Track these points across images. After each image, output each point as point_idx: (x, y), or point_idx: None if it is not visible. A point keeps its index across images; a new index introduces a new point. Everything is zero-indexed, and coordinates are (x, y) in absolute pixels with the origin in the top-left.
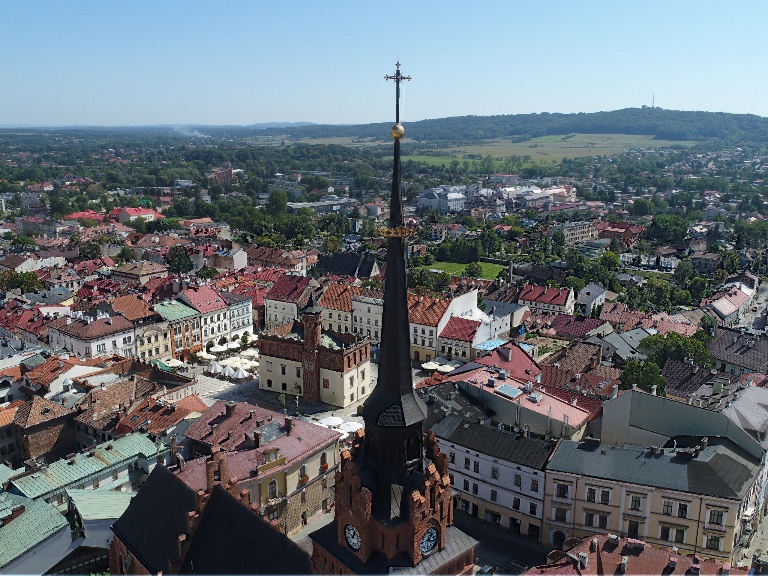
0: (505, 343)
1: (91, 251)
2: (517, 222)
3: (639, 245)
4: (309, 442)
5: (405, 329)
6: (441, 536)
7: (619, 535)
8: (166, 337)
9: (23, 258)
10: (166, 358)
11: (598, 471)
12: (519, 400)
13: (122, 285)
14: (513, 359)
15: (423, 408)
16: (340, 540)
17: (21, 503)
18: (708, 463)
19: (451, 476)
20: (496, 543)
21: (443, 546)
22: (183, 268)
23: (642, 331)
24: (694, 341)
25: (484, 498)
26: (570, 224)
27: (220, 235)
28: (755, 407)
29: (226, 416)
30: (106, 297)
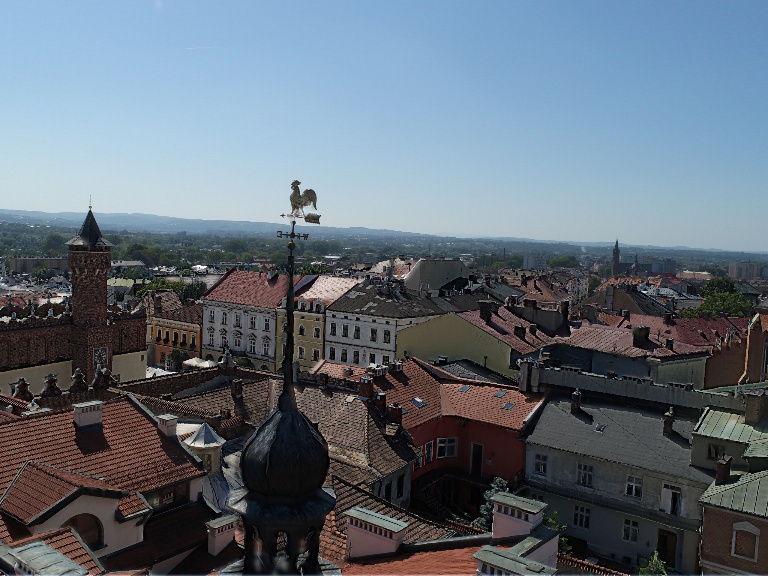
0: (226, 274)
1: None
2: None
3: None
4: None
5: None
6: None
7: None
8: None
9: None
10: None
11: None
12: None
13: None
14: None
15: None
16: None
17: None
18: None
19: None
20: None
21: None
22: None
23: None
24: None
25: None
26: None
27: None
28: None
29: None
30: None
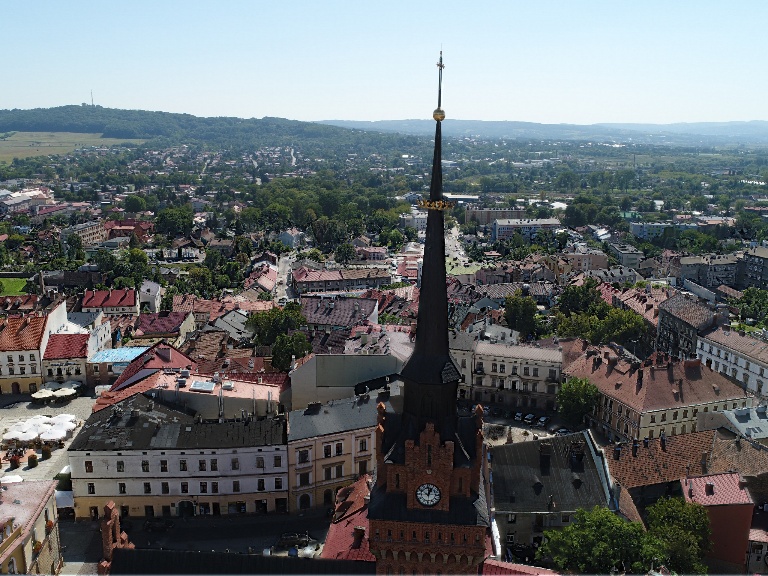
0: (154, 345)
1: None
2: (11, 230)
3: (156, 240)
4: (30, 502)
5: None
6: None
7: (353, 478)
8: None
9: None
10: None
11: (331, 428)
12: (221, 391)
13: None
14: (172, 358)
15: None
16: (411, 505)
17: None
18: (401, 395)
19: (183, 485)
20: (252, 529)
21: None
22: None
23: (236, 313)
24: (291, 312)
25: (226, 493)
26: (78, 226)
27: None
28: (402, 346)
29: None
30: None
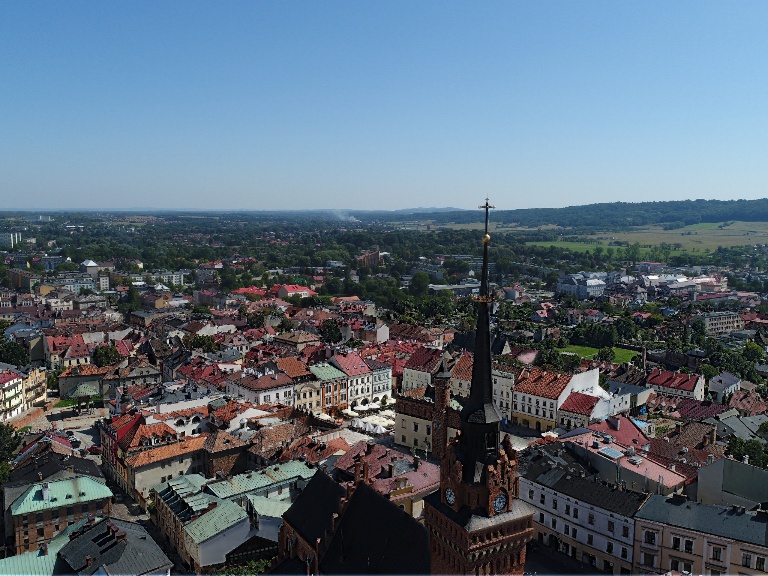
0: None
1: (257, 321)
2: (657, 310)
3: None
4: (433, 478)
5: (488, 361)
6: (509, 502)
7: None
8: (319, 394)
9: (202, 324)
10: (317, 412)
11: (682, 522)
12: (619, 460)
13: (283, 350)
14: (622, 429)
15: (499, 415)
16: (442, 499)
17: (214, 501)
18: None
19: (554, 521)
20: None
21: (510, 509)
22: (333, 339)
23: (765, 417)
24: None
25: (582, 541)
26: (713, 314)
27: (366, 312)
28: None
29: (367, 453)
30: (273, 357)
